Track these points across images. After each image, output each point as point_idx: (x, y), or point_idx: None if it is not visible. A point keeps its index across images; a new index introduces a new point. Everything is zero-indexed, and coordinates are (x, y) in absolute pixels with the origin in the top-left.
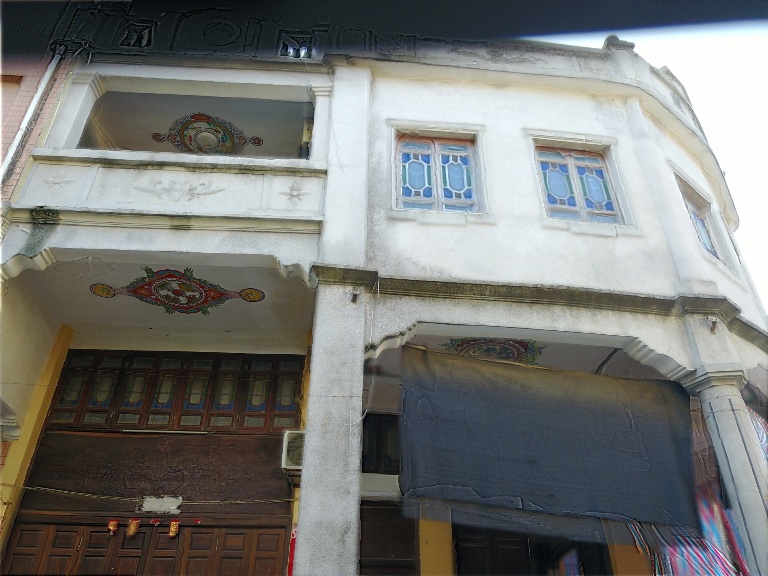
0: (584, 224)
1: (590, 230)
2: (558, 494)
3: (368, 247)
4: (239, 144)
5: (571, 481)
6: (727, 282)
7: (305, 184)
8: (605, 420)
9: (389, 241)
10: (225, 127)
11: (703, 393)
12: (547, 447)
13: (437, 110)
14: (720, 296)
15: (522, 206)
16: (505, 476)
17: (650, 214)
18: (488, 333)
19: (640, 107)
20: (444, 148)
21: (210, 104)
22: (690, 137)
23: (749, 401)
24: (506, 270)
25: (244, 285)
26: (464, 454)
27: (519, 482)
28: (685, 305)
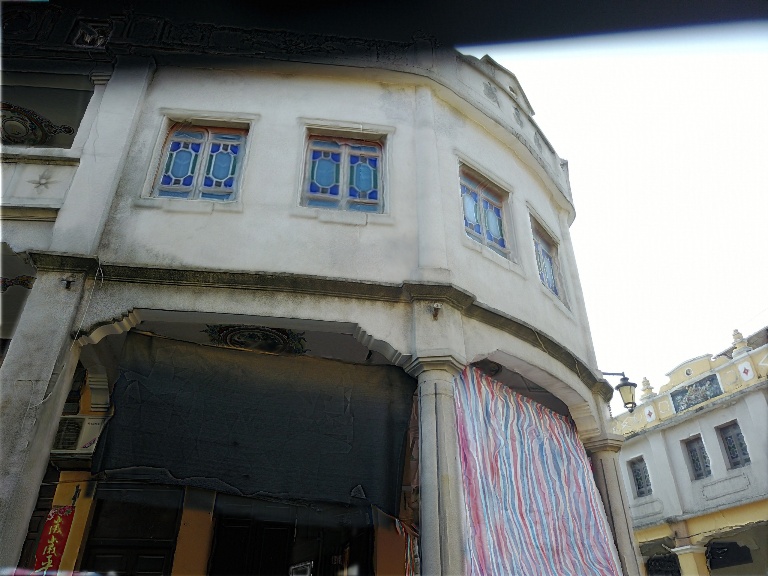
0: (335, 212)
1: (339, 218)
2: (252, 475)
3: (104, 235)
4: (50, 132)
5: (266, 463)
6: (492, 270)
7: (57, 172)
8: (318, 404)
9: (128, 229)
10: (30, 115)
11: (418, 378)
12: (250, 430)
13: (216, 99)
14: (445, 283)
15: (276, 194)
16: (200, 458)
17: (408, 203)
18: (211, 319)
19: (434, 97)
20: (217, 137)
21: (2, 92)
22: (494, 126)
23: (514, 386)
24: (240, 257)
25: (16, 272)
26: (162, 437)
27: (214, 464)
28: (411, 292)
